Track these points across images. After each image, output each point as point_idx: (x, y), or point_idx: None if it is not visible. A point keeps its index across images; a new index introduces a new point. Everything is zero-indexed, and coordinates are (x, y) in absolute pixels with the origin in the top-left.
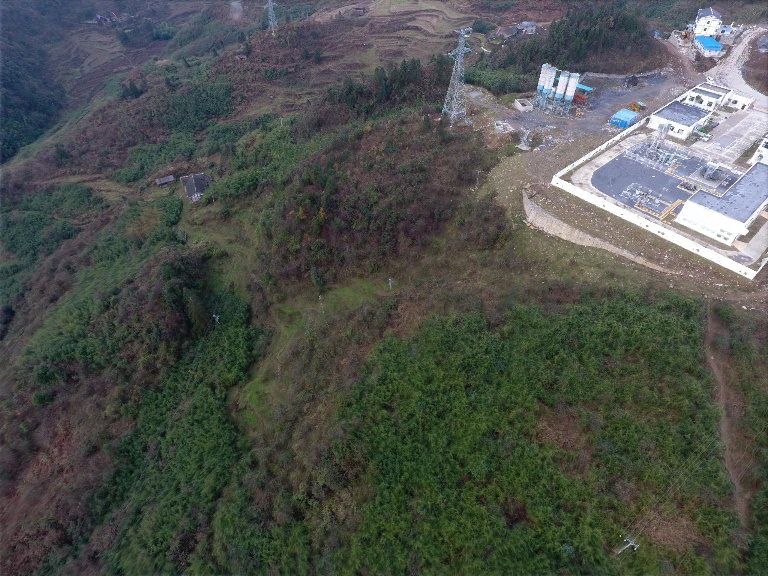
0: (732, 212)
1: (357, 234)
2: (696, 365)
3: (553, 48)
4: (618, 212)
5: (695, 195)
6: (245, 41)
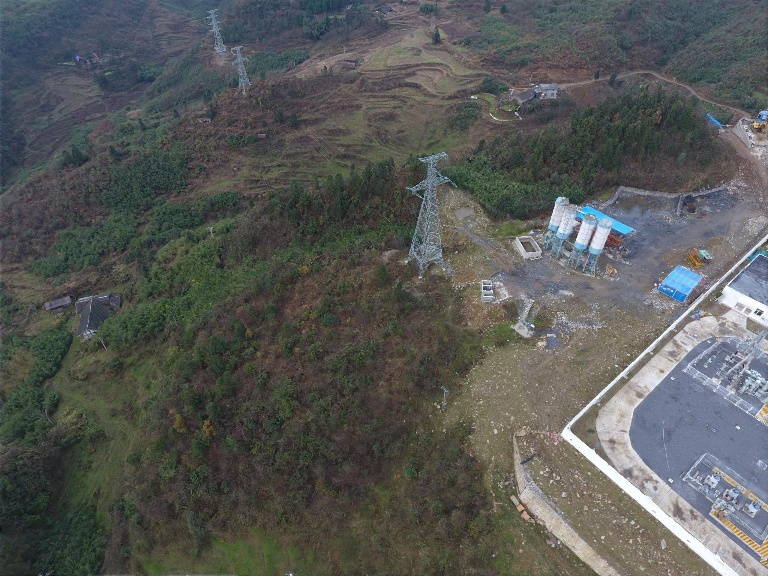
0: None
1: (257, 466)
2: None
3: (575, 149)
4: (681, 535)
5: None
6: (212, 100)
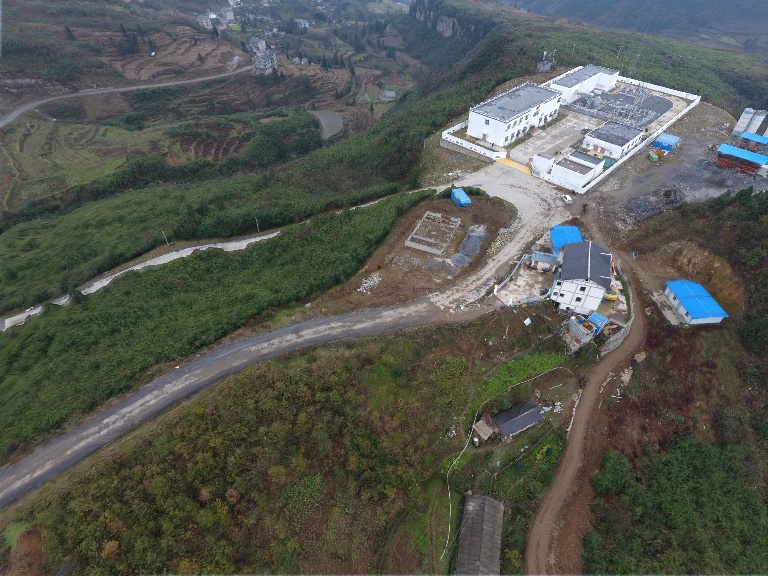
0: None
1: None
2: None
3: None
4: (649, 87)
5: None
6: None
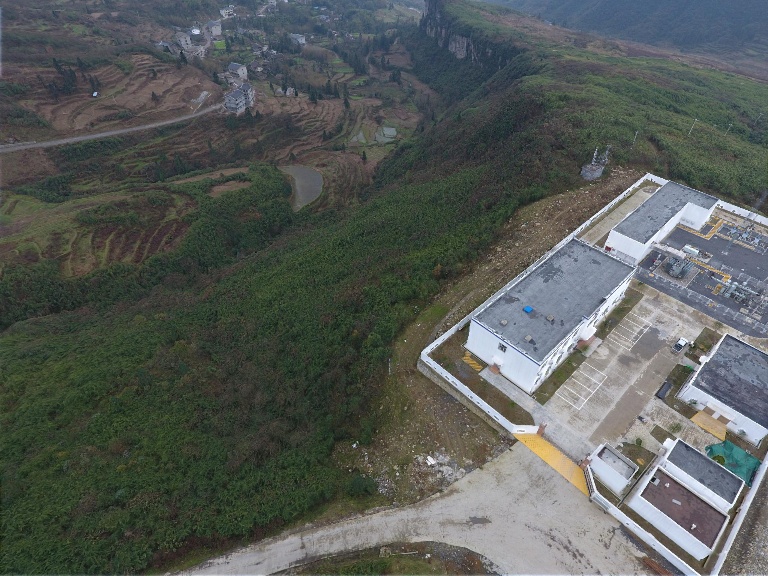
0: (678, 191)
1: None
2: (676, 155)
3: None
4: (766, 223)
5: None
6: None
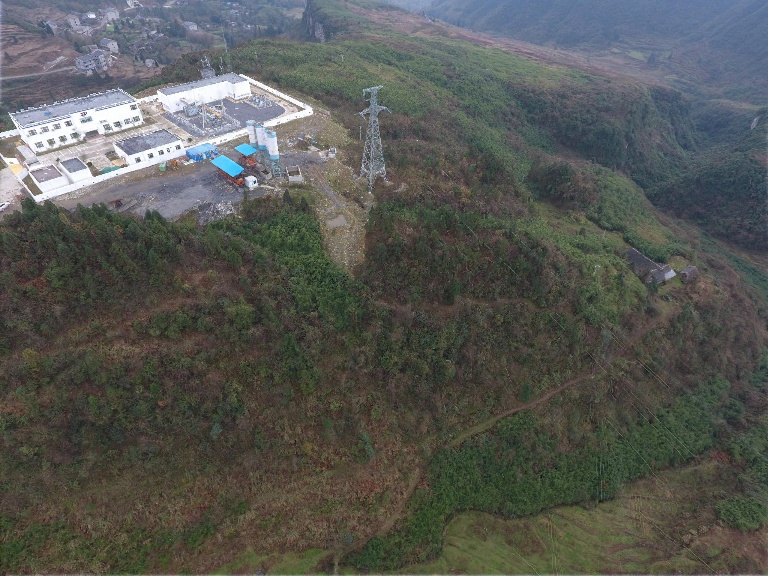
0: (230, 77)
1: None
2: None
3: None
4: None
5: (240, 83)
6: None
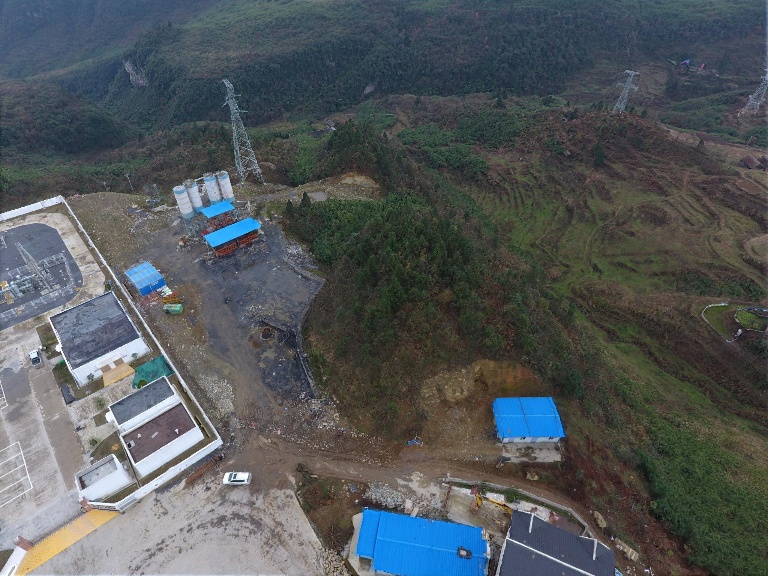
0: None
1: None
2: None
3: None
4: None
5: None
6: None
